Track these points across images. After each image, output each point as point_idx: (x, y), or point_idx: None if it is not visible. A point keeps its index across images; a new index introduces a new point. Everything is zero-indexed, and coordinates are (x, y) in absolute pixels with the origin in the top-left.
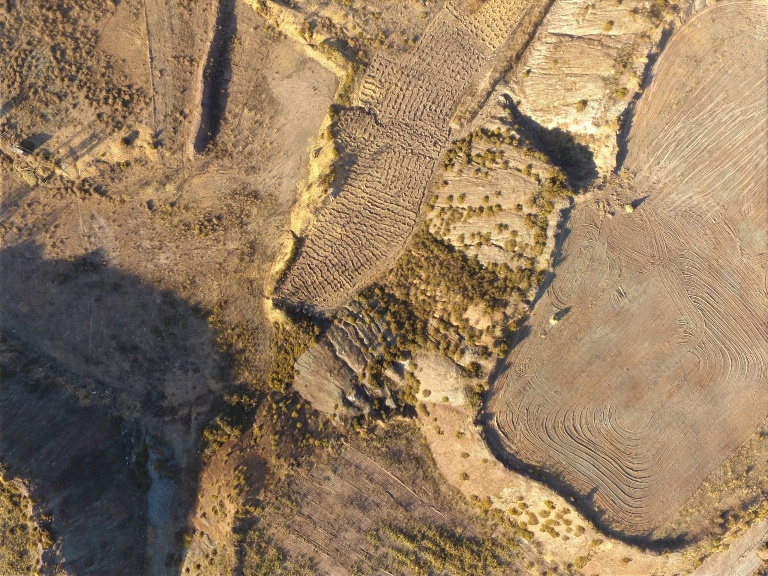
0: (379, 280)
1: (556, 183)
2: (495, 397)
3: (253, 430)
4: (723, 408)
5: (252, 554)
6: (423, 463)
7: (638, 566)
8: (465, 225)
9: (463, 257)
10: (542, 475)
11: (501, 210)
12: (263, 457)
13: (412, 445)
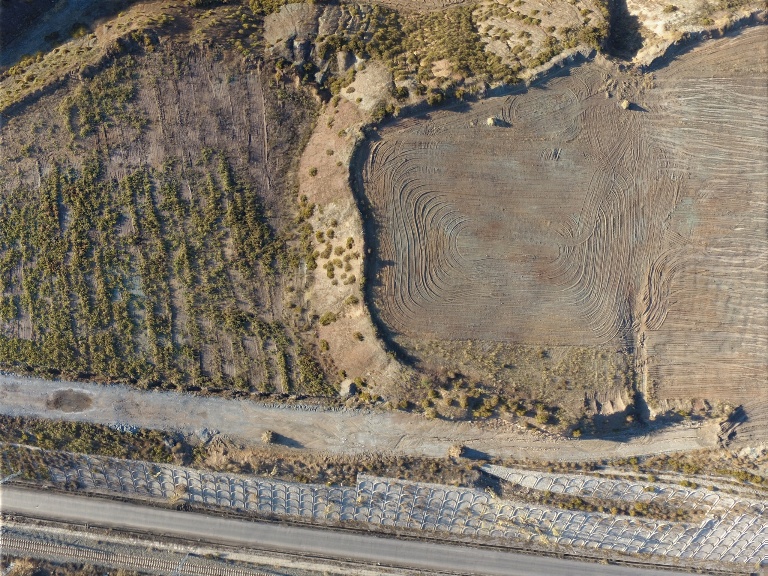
0: (402, 12)
1: (596, 32)
2: (394, 129)
3: (206, 12)
4: (538, 307)
5: (113, 71)
6: (295, 142)
7: (363, 351)
8: (502, 21)
9: (477, 38)
10: (367, 213)
11: (538, 24)
12: (193, 25)
13: (302, 121)
